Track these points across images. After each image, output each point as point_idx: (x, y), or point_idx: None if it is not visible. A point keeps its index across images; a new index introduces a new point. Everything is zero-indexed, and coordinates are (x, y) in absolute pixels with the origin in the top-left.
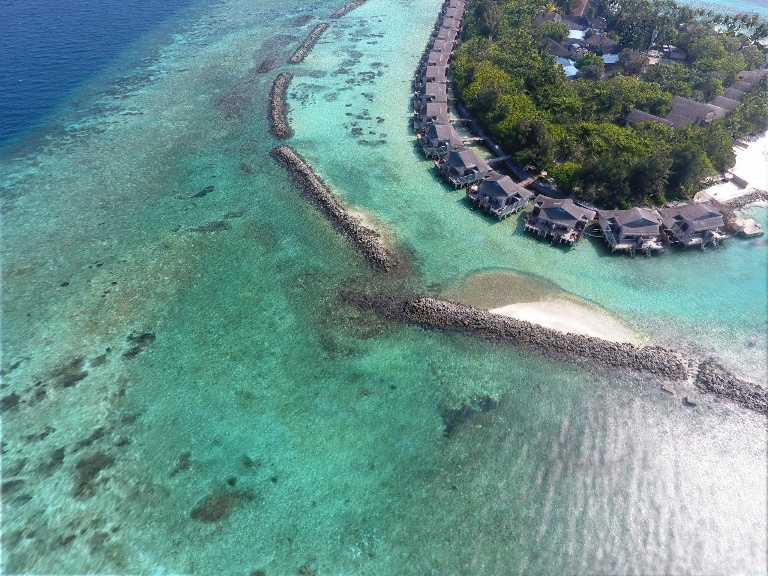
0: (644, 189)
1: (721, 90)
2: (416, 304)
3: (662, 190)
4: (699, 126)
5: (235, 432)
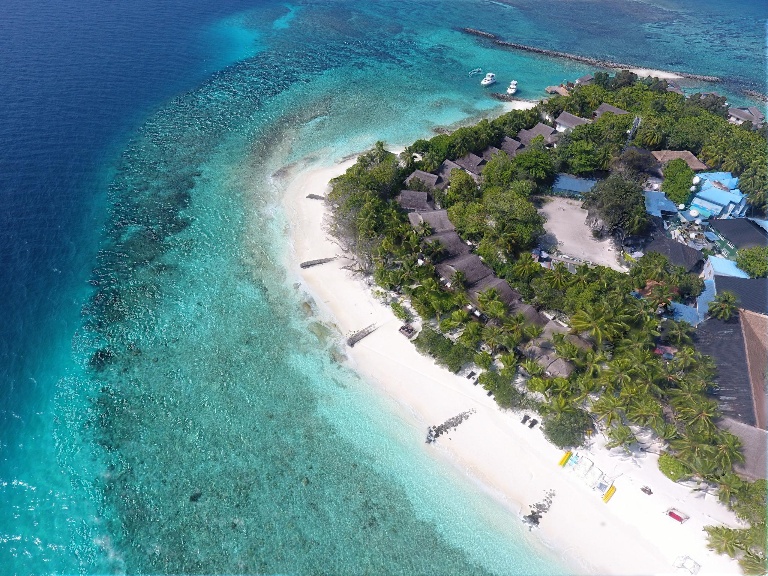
0: None
1: None
2: None
3: None
4: None
5: None
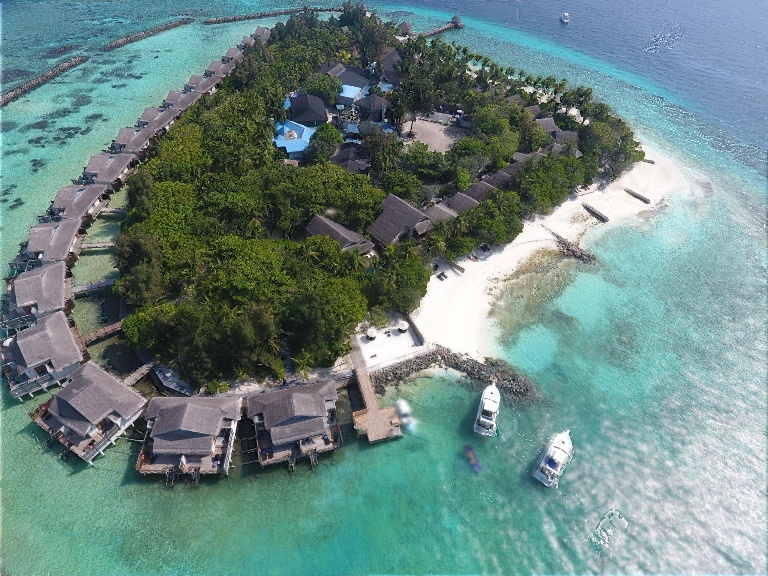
0: (239, 360)
1: (465, 184)
2: None
3: (276, 357)
4: (412, 237)
5: None
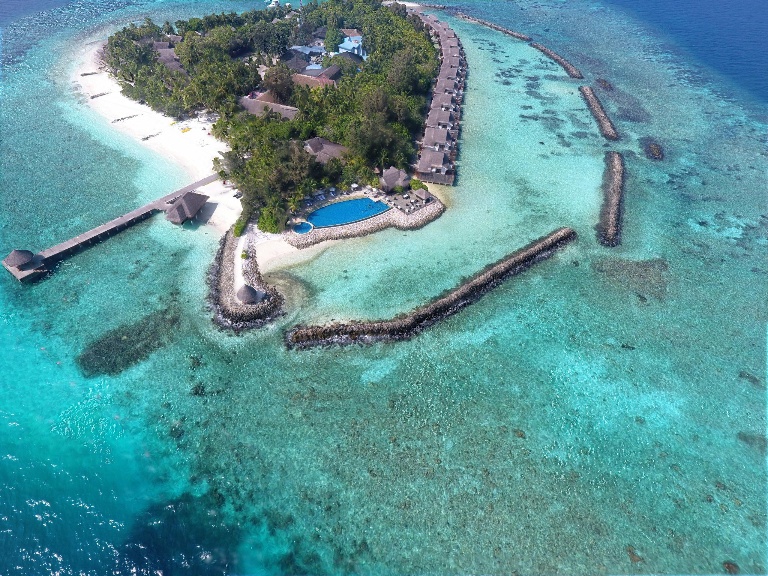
0: None
1: None
2: (445, 6)
3: None
4: None
5: (484, 1)
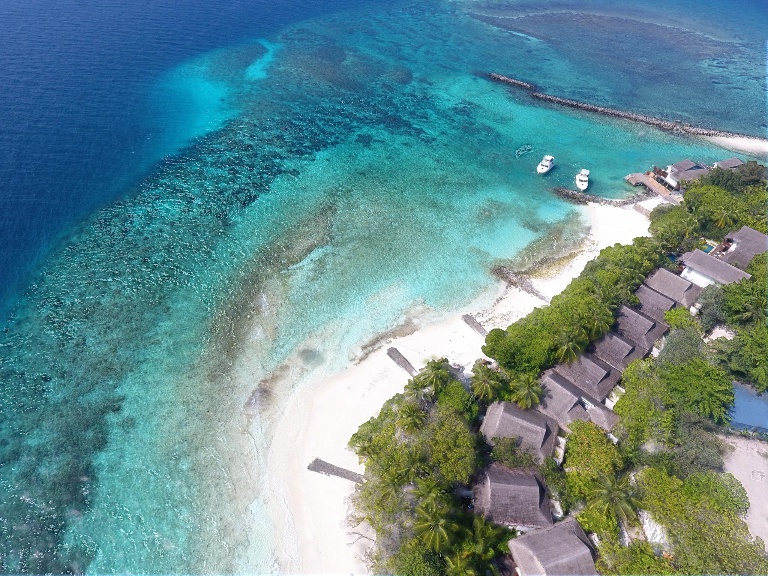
0: None
1: None
2: None
3: None
4: None
5: None
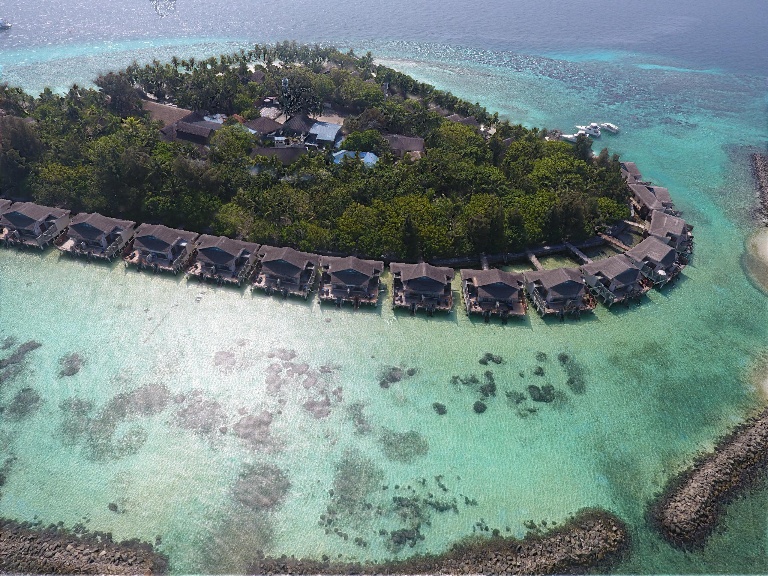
0: None
1: None
2: None
3: None
4: None
5: None
